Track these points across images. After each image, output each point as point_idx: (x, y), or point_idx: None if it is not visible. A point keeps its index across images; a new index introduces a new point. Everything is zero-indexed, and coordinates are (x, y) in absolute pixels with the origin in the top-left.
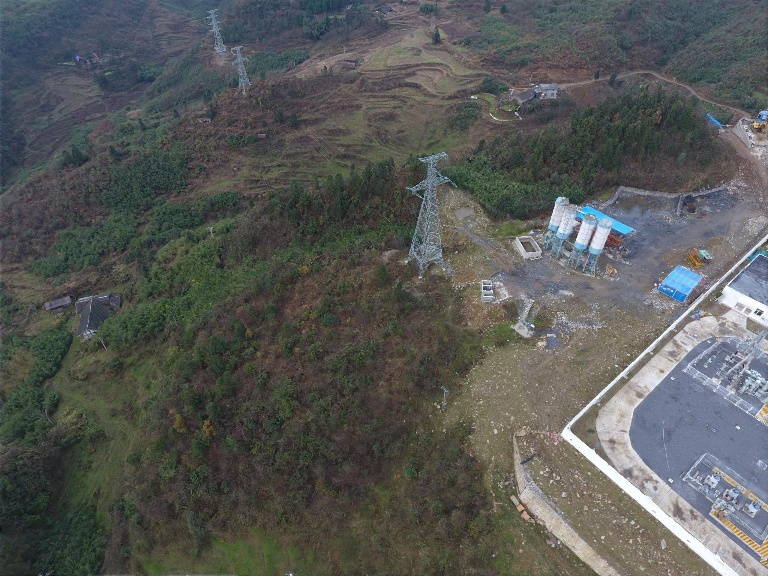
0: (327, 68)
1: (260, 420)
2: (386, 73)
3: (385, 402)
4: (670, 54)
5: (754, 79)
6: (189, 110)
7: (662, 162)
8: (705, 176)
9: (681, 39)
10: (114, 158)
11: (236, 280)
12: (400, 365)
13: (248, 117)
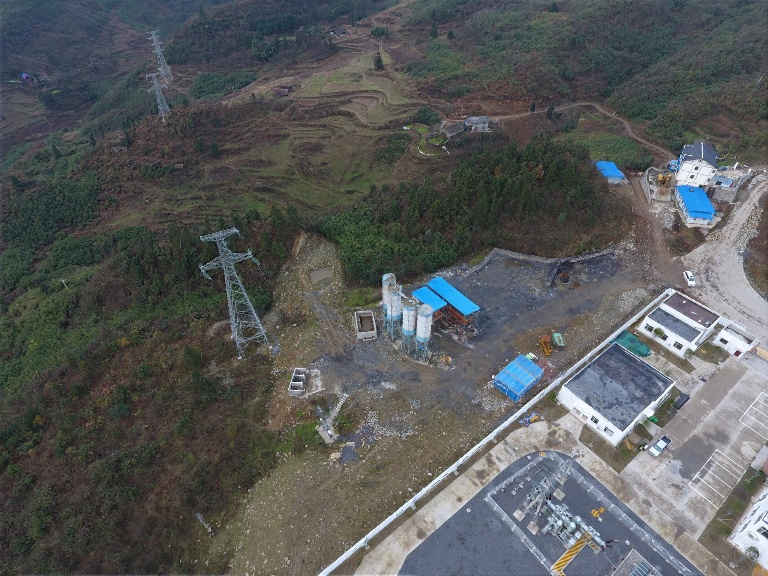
0: (264, 93)
1: (7, 539)
2: (319, 101)
3: (142, 525)
4: (615, 85)
5: (686, 118)
6: (105, 138)
7: (540, 222)
8: (589, 238)
9: (627, 70)
10: (17, 189)
11: (71, 344)
12: (178, 474)
13: (166, 146)
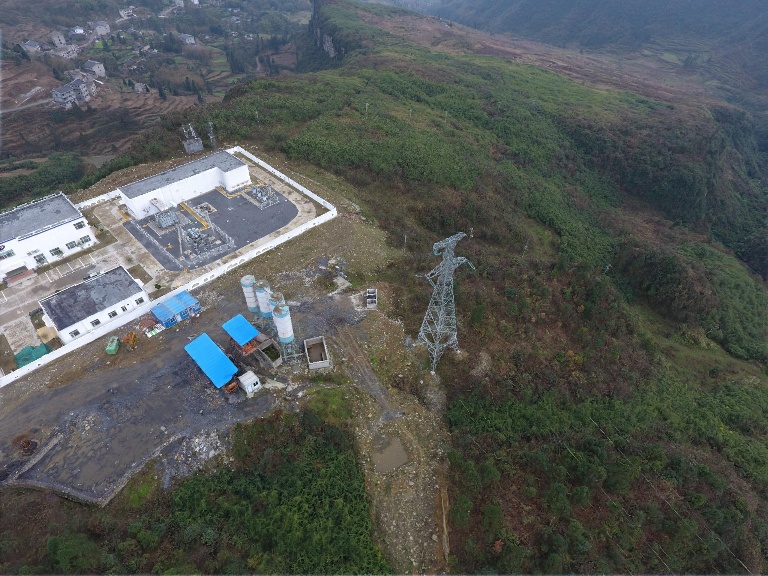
0: None
1: None
2: None
3: None
4: None
5: None
6: None
7: None
8: None
9: None
10: None
11: None
12: None
13: None
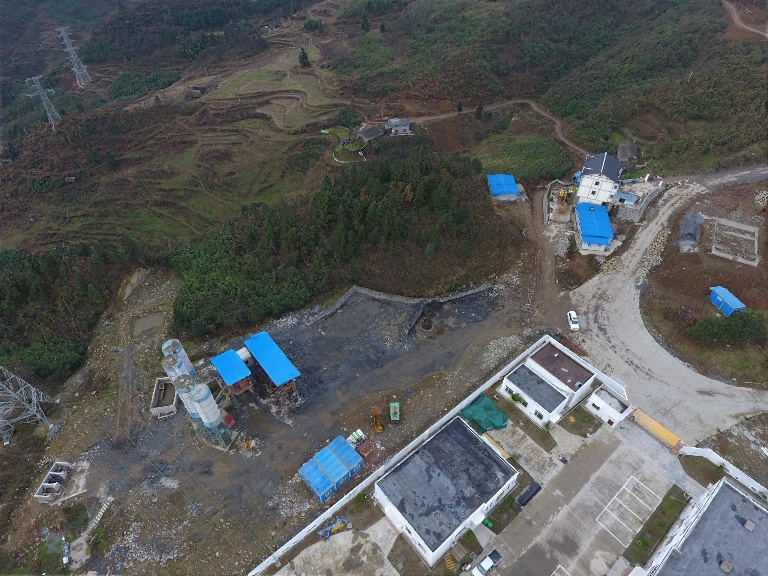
0: (178, 95)
1: None
2: (233, 102)
3: None
4: (552, 81)
5: (615, 118)
6: None
7: (405, 255)
8: (464, 271)
9: (566, 64)
10: None
11: None
12: None
13: (56, 157)
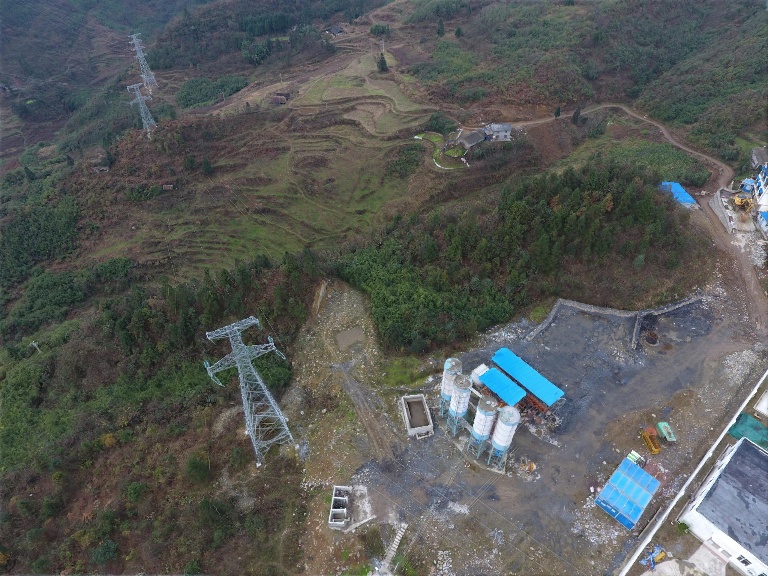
0: (258, 101)
1: None
2: (320, 109)
3: None
4: (642, 85)
5: (736, 123)
6: (84, 157)
7: (613, 267)
8: (671, 283)
9: (654, 67)
10: None
11: (45, 430)
12: None
13: (153, 165)
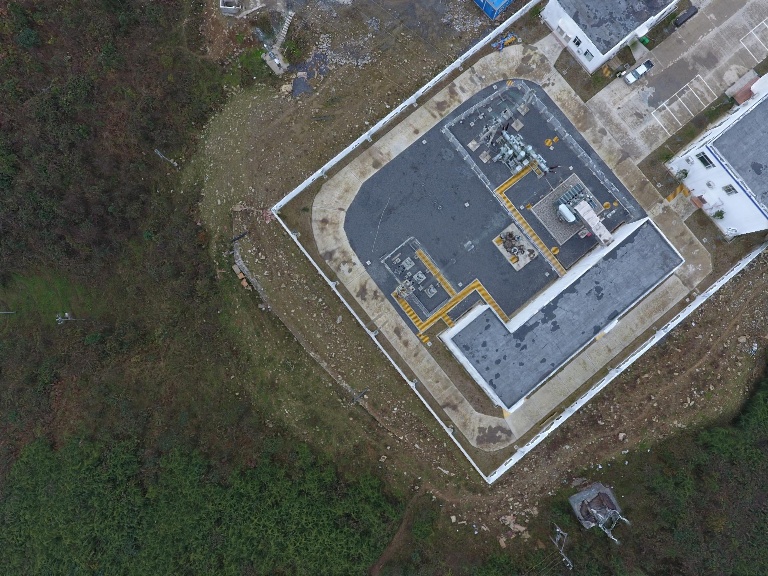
0: None
1: None
2: None
3: (107, 161)
4: None
5: None
6: None
7: None
8: None
9: None
10: None
11: None
12: (124, 111)
13: None
